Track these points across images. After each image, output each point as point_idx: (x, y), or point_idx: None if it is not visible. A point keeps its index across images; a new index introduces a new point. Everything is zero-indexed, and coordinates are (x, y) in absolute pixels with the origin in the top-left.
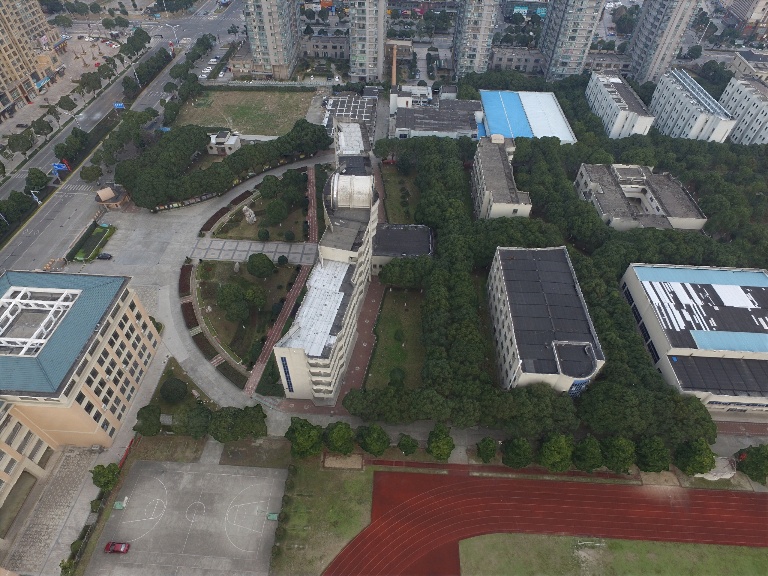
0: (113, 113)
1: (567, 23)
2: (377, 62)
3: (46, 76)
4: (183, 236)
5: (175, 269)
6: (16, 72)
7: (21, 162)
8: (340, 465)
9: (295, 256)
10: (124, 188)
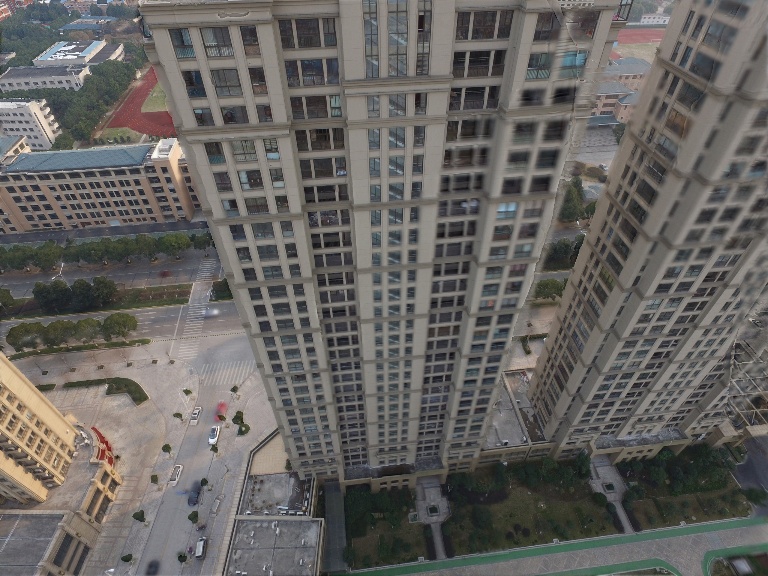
0: None
1: None
2: None
3: None
4: None
5: None
6: None
7: None
8: (99, 135)
9: None
10: None
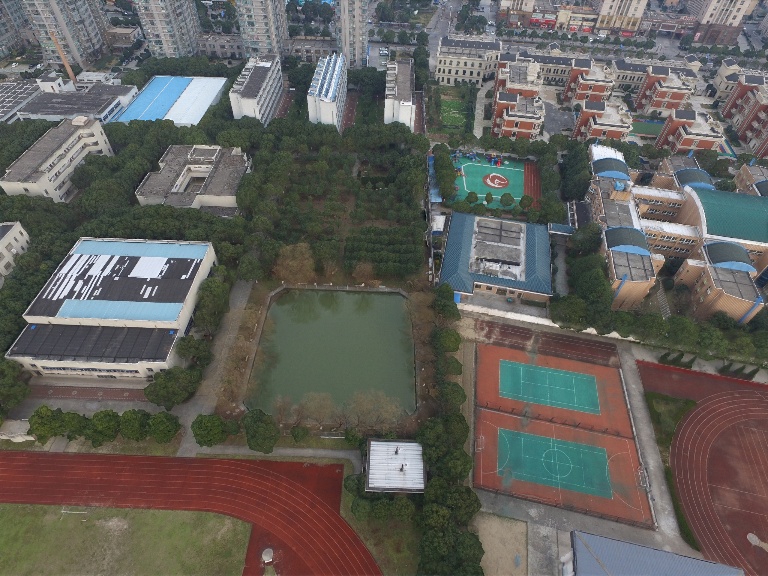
0: None
1: (239, 9)
2: (71, 49)
3: None
4: None
5: None
6: None
7: None
8: None
9: None
10: None
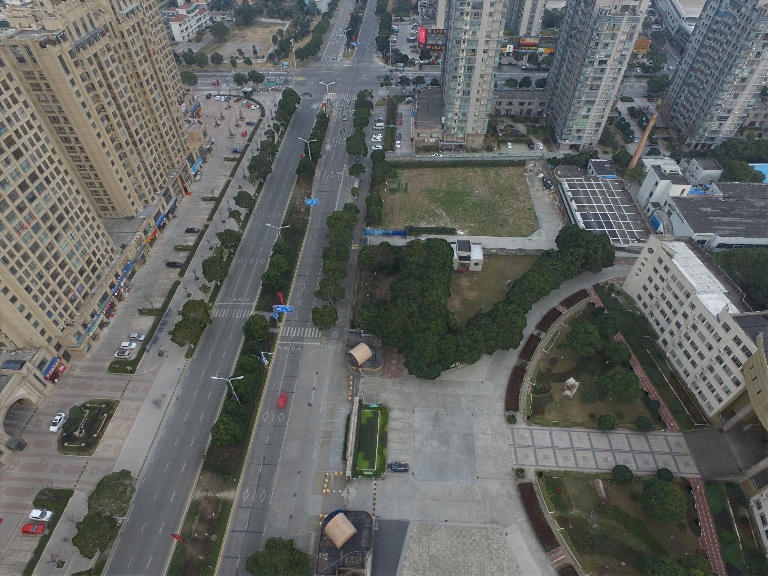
0: (294, 206)
1: None
2: None
3: (199, 156)
4: (486, 422)
5: (508, 490)
6: (174, 158)
7: (213, 290)
8: None
9: (665, 459)
10: (378, 340)
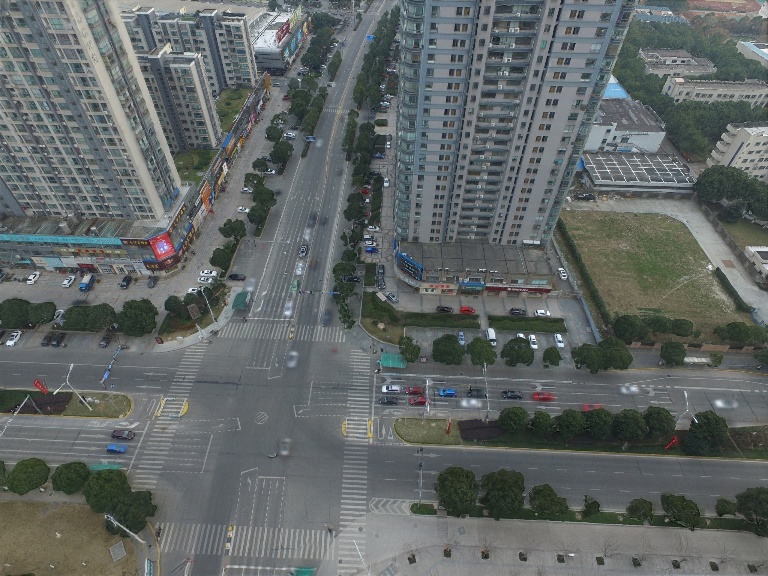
0: None
1: None
2: None
3: None
4: None
5: None
6: None
7: None
8: None
9: None
10: None
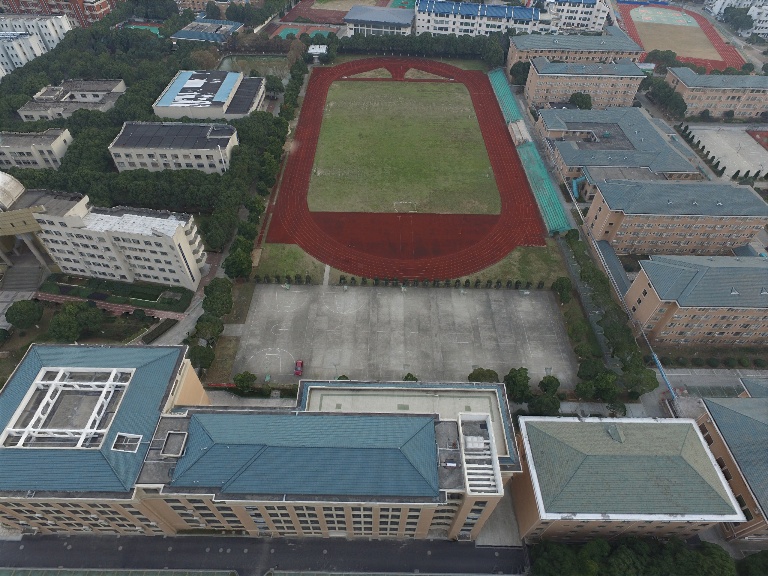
0: None
1: None
2: None
3: None
4: None
5: None
6: None
7: None
8: (258, 259)
9: None
10: None
